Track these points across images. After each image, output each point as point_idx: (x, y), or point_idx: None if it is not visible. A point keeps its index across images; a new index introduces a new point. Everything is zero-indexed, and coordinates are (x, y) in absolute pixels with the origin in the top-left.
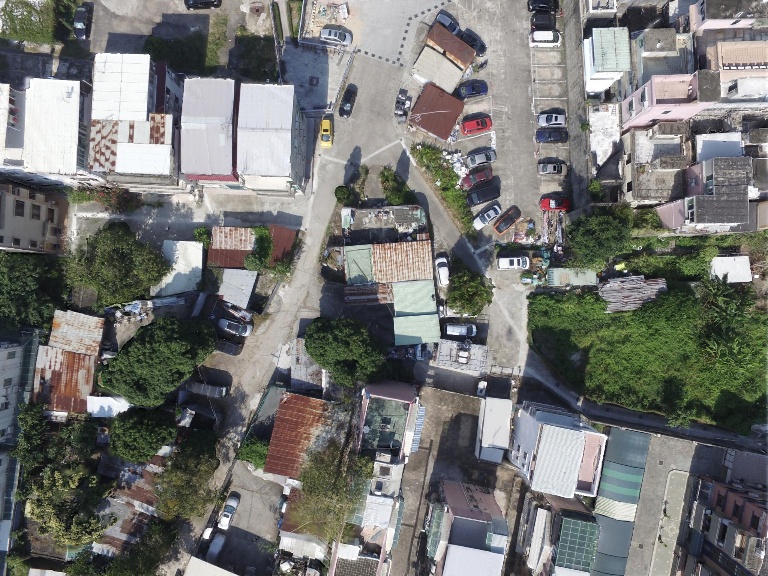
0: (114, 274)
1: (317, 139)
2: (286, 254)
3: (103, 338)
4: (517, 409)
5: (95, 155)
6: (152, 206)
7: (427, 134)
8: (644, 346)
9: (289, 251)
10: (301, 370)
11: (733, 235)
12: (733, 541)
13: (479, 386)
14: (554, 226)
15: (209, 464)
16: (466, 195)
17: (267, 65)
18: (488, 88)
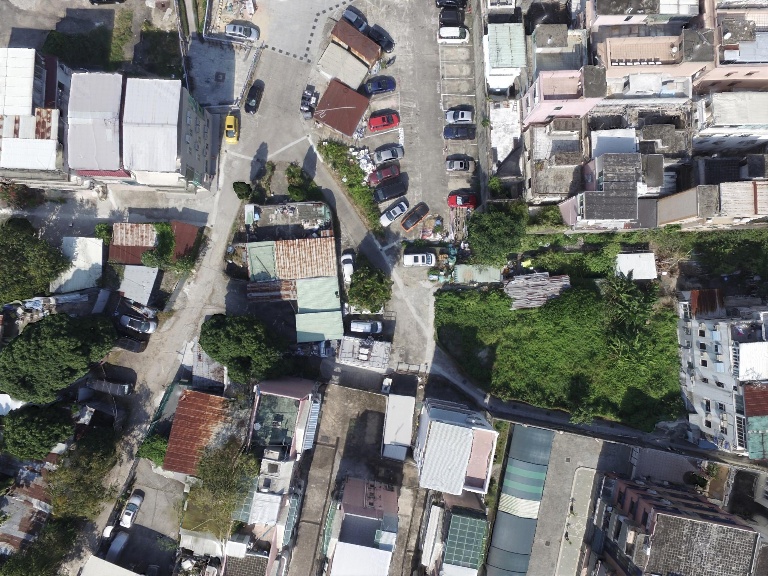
0: (3, 270)
1: (223, 135)
2: (188, 251)
3: (4, 335)
4: (422, 406)
5: None
6: (55, 202)
7: (334, 130)
8: (551, 343)
9: (191, 247)
10: (203, 367)
11: (637, 232)
12: (624, 538)
13: (384, 383)
14: (462, 223)
15: (101, 462)
16: (373, 192)
17: (173, 61)
18: (396, 84)
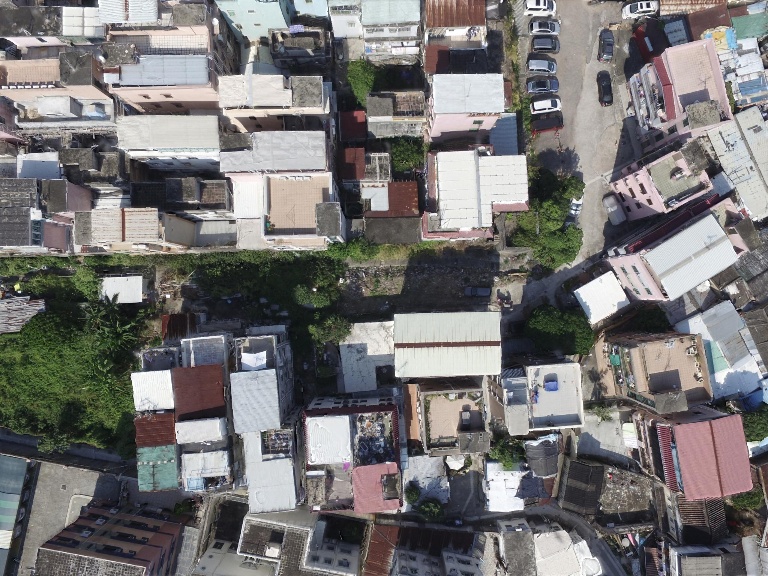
0: None
1: None
2: None
3: None
4: None
5: None
6: None
7: None
8: (46, 368)
9: None
10: None
11: (117, 255)
12: None
13: None
14: None
15: None
16: None
17: None
18: None
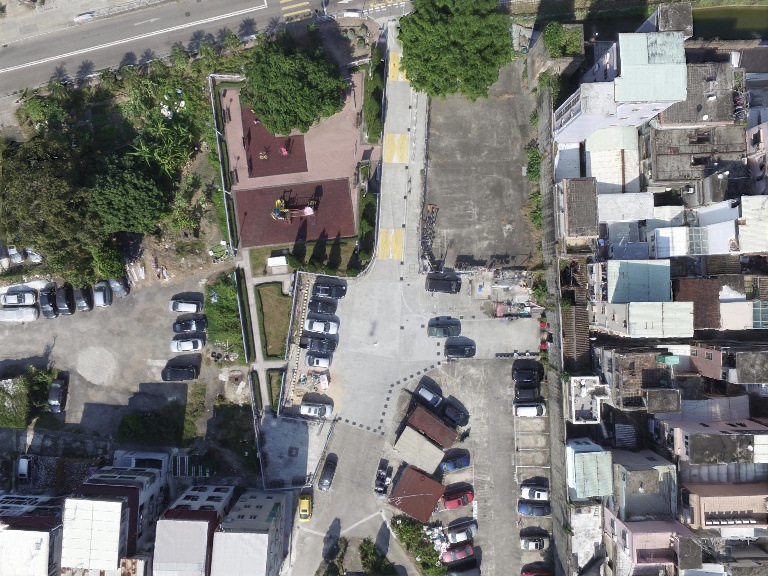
0: None
1: (296, 512)
2: None
3: None
4: None
5: None
6: None
7: None
8: None
9: None
10: None
11: None
12: None
13: None
14: None
15: None
16: (446, 569)
17: (246, 435)
18: (470, 457)
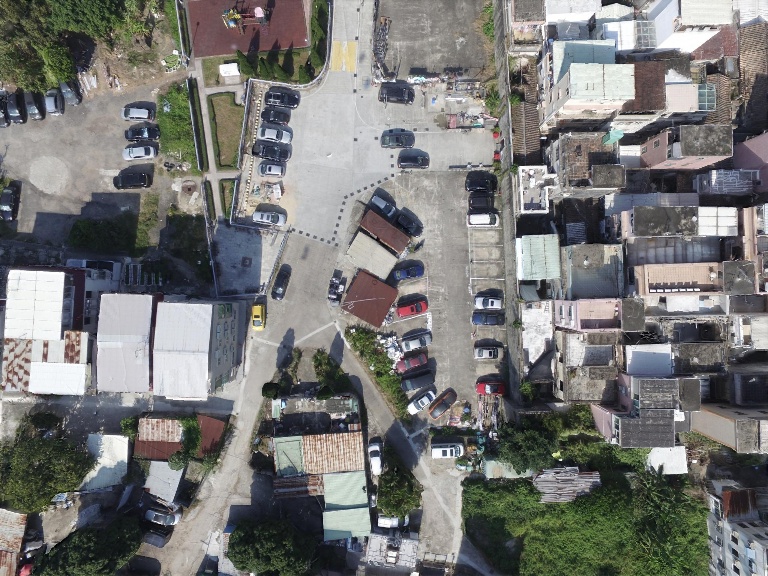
0: (30, 488)
1: (249, 321)
2: (214, 445)
3: (28, 528)
4: None
5: (8, 375)
6: None
7: None
8: (579, 533)
9: (218, 442)
10: (228, 564)
11: None
12: None
13: None
14: (490, 409)
15: None
16: (401, 379)
17: (199, 245)
18: (425, 268)
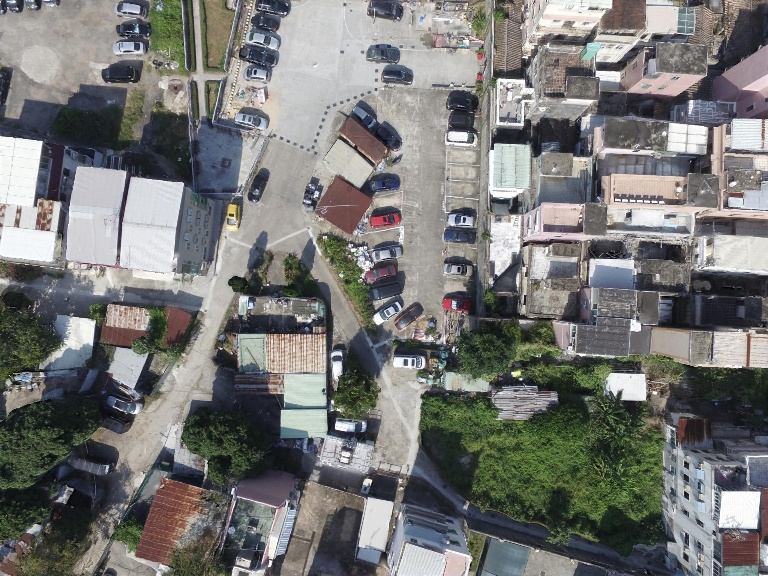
0: None
1: (224, 221)
2: (180, 337)
3: None
4: (400, 510)
5: None
6: (53, 276)
7: None
8: (535, 455)
9: (183, 334)
10: (185, 455)
11: None
12: None
13: (364, 483)
14: (455, 326)
15: (75, 550)
16: (369, 289)
17: (181, 143)
18: (400, 183)
